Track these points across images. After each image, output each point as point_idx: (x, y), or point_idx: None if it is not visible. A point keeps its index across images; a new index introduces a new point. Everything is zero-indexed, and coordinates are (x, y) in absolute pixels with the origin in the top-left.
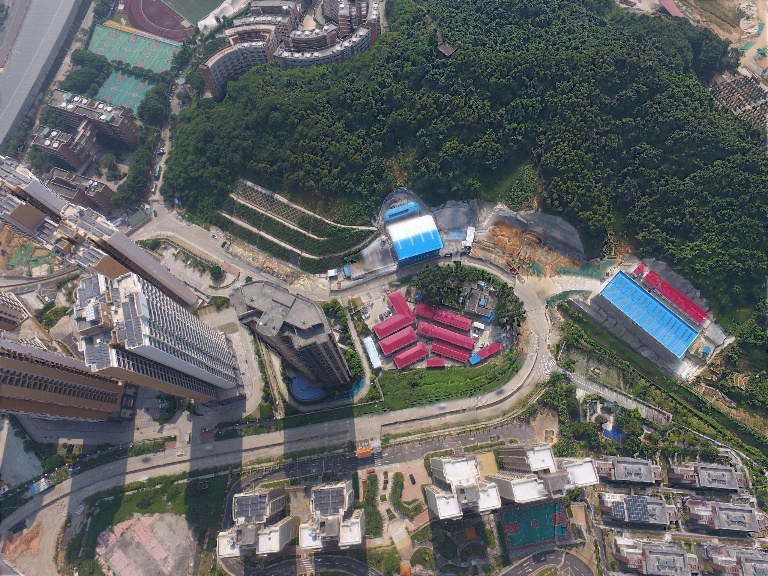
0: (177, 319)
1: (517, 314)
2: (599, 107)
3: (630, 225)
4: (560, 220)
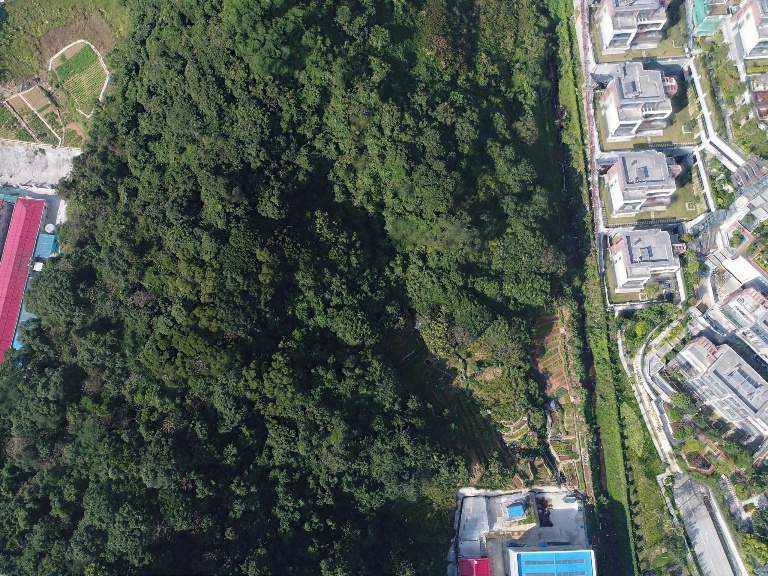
0: None
1: None
2: None
3: None
4: None
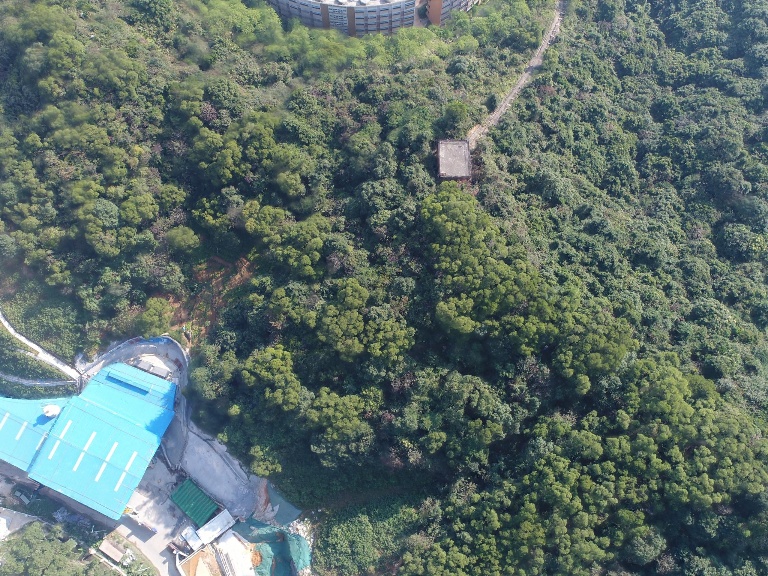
0: None
1: None
2: (623, 543)
3: None
4: None
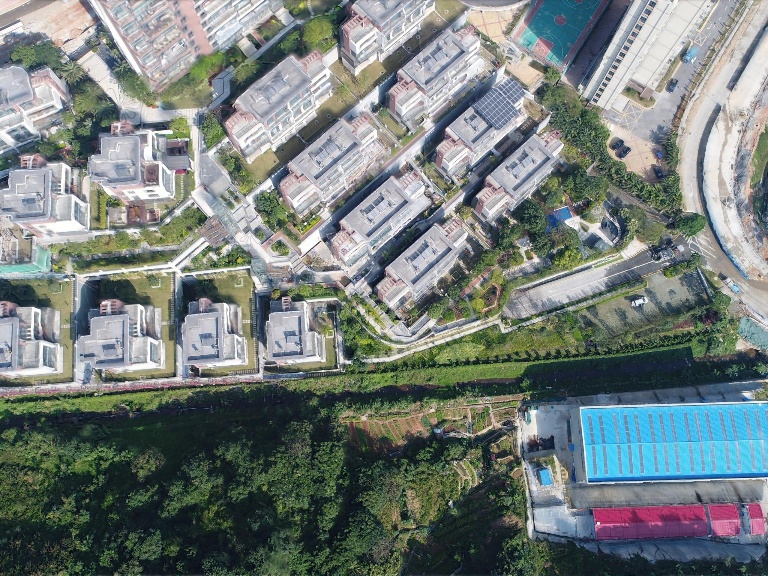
0: None
1: None
2: None
3: None
4: None
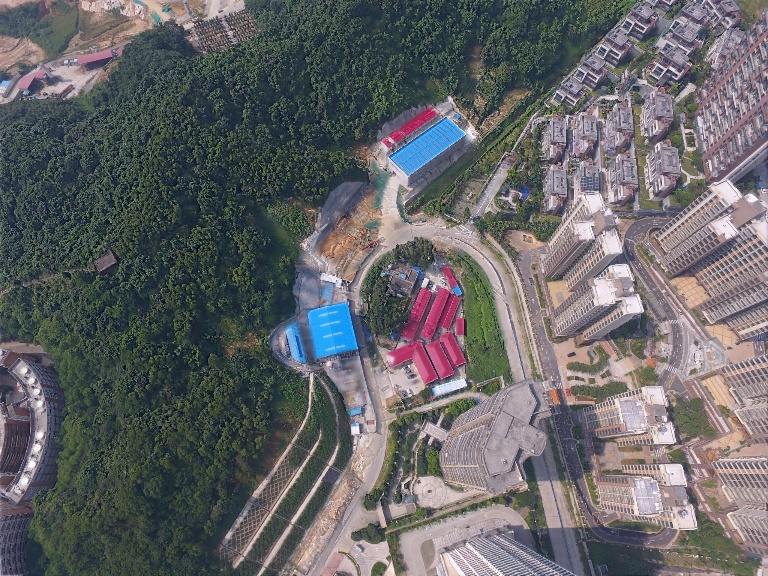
0: (505, 574)
1: (427, 244)
2: None
3: (343, 141)
4: (333, 193)
